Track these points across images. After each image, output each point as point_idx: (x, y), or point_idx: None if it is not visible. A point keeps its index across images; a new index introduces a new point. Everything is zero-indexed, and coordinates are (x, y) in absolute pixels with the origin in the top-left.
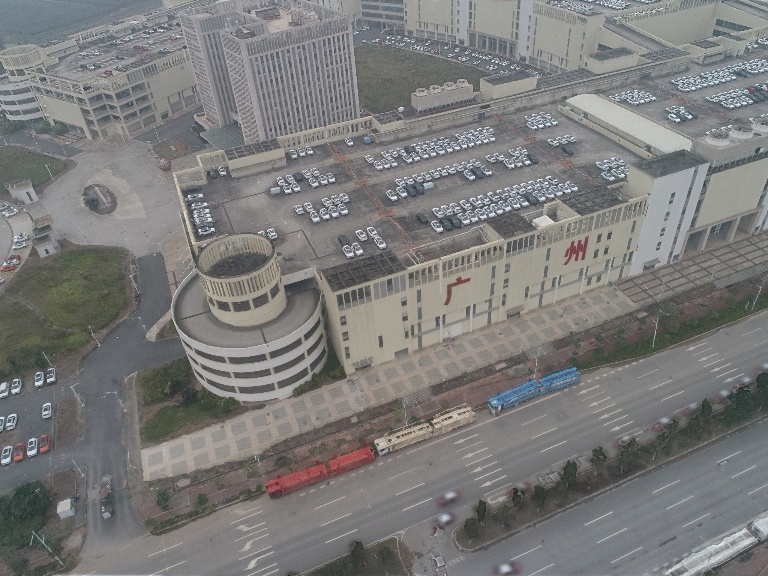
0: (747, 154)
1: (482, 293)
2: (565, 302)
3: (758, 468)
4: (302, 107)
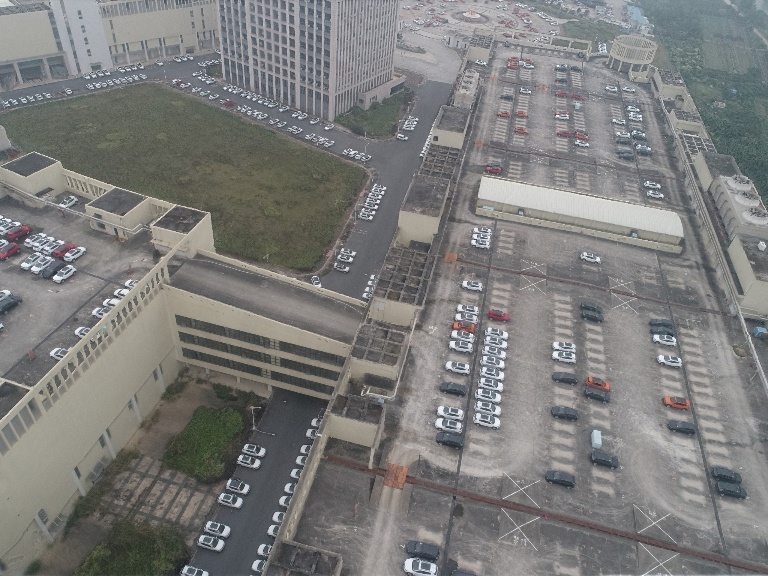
0: None
1: None
2: None
3: None
4: None
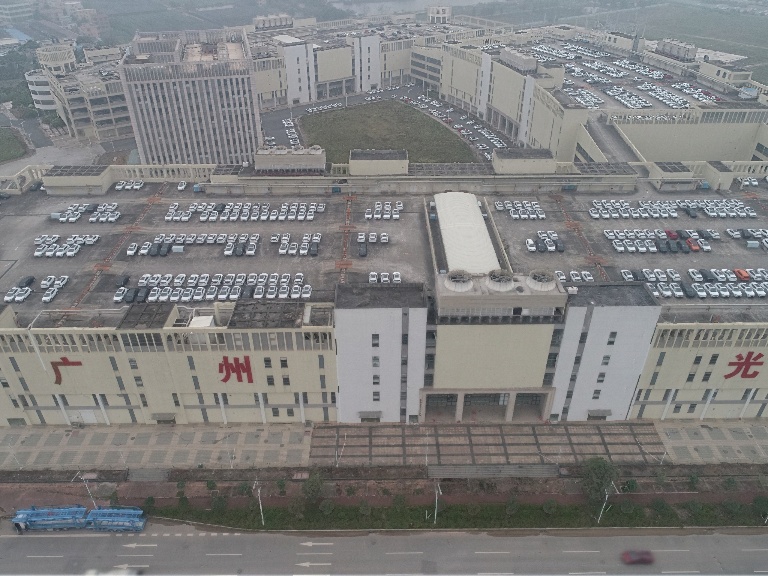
0: (499, 311)
1: (107, 384)
2: (238, 427)
3: None
4: (192, 143)
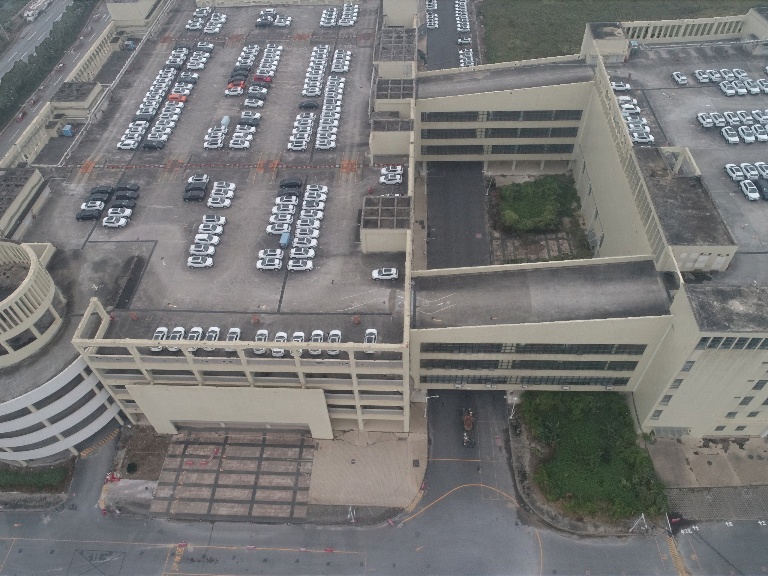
0: None
1: None
2: None
3: (71, 2)
4: None
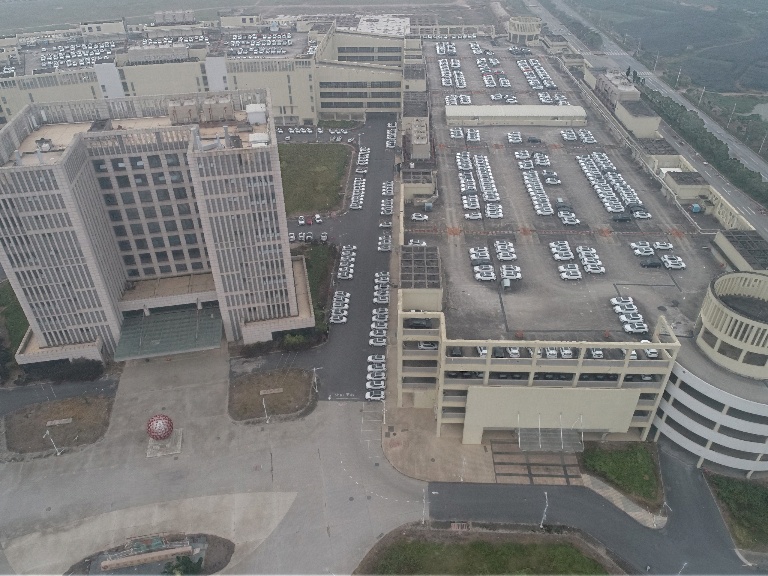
0: None
1: None
2: None
3: None
4: None
